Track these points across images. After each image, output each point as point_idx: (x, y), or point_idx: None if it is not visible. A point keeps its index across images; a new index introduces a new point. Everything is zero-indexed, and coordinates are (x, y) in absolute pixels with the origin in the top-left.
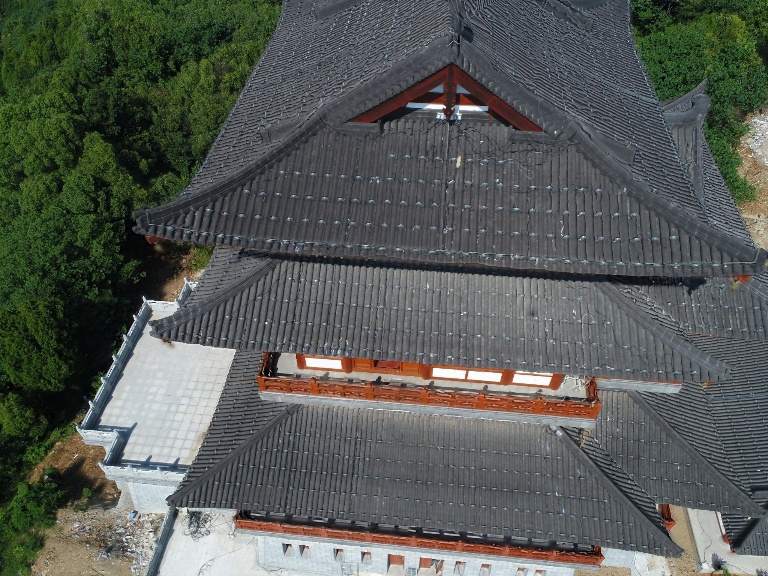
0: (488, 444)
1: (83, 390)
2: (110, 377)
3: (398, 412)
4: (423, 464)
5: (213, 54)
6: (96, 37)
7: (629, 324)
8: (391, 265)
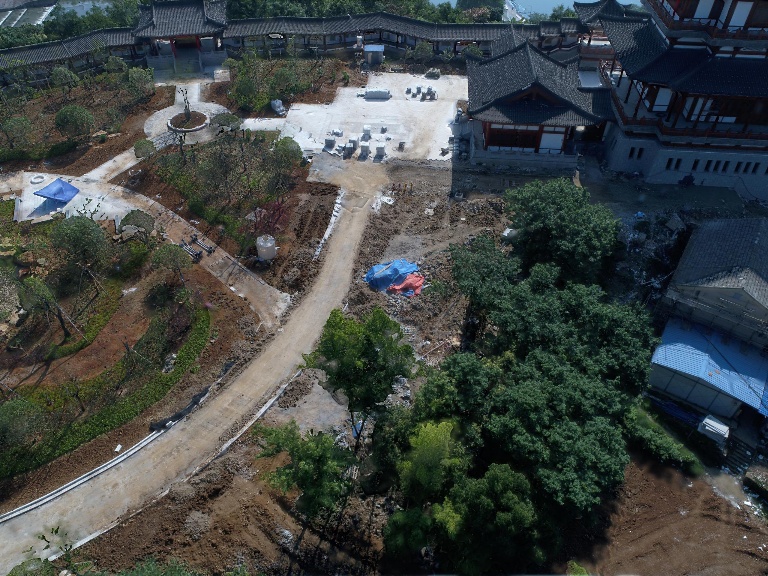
0: None
1: None
2: None
3: None
4: None
5: None
6: None
7: None
8: None
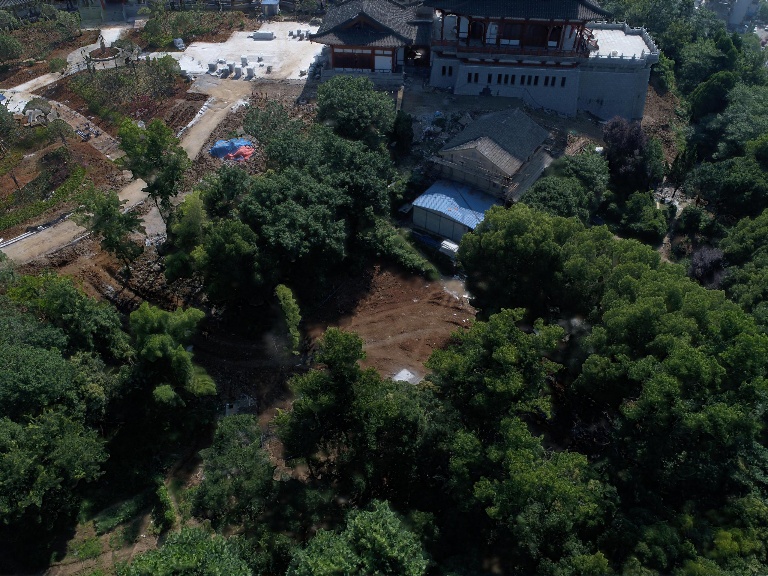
0: None
1: None
2: None
3: None
4: None
5: None
6: None
7: None
8: None
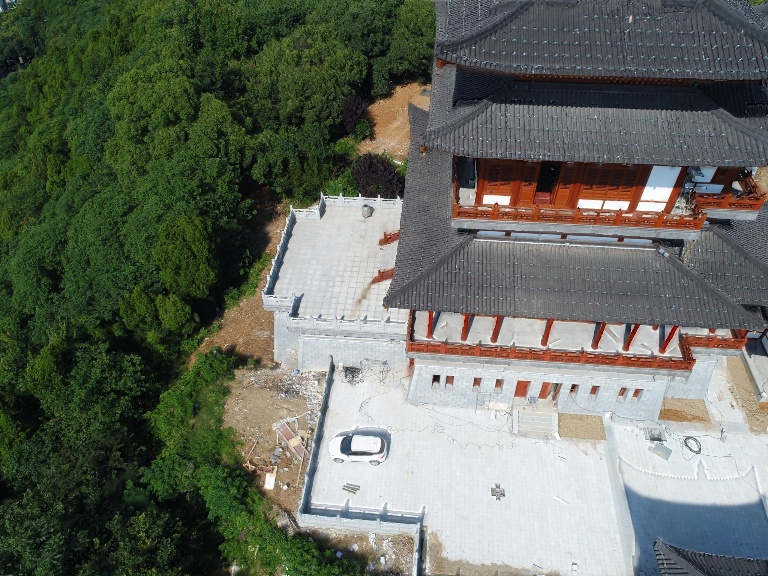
0: (613, 265)
1: (216, 302)
2: (276, 262)
3: (543, 245)
4: (566, 279)
5: (291, 34)
6: (185, 21)
7: (737, 135)
8: (569, 104)
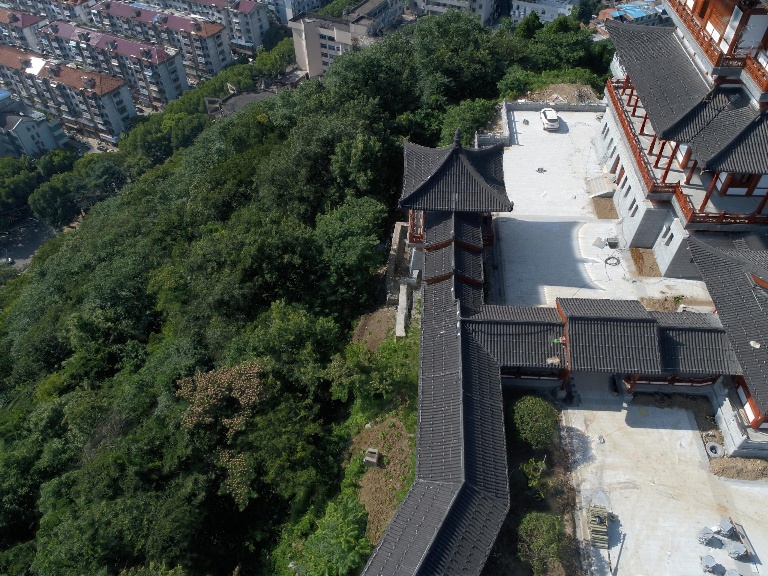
0: None
1: None
2: None
3: (686, 54)
4: None
5: None
6: None
7: None
8: None
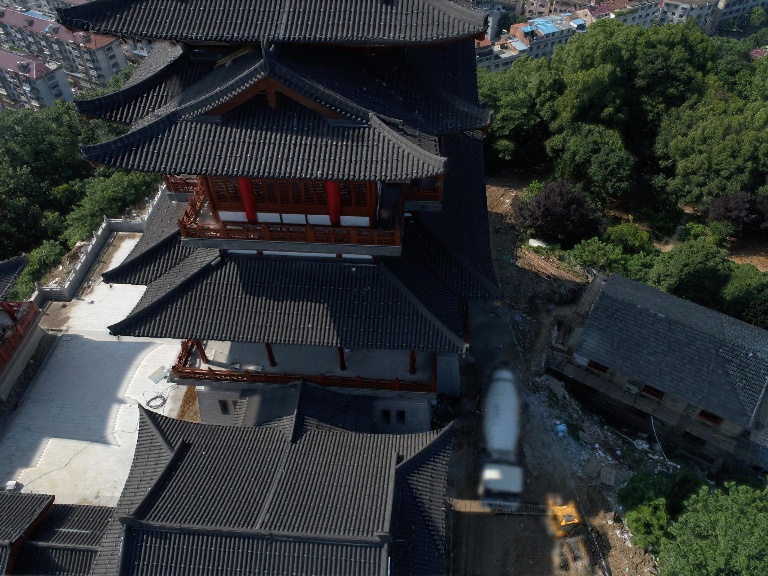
0: None
1: None
2: None
3: None
4: None
5: None
6: None
7: None
8: None
